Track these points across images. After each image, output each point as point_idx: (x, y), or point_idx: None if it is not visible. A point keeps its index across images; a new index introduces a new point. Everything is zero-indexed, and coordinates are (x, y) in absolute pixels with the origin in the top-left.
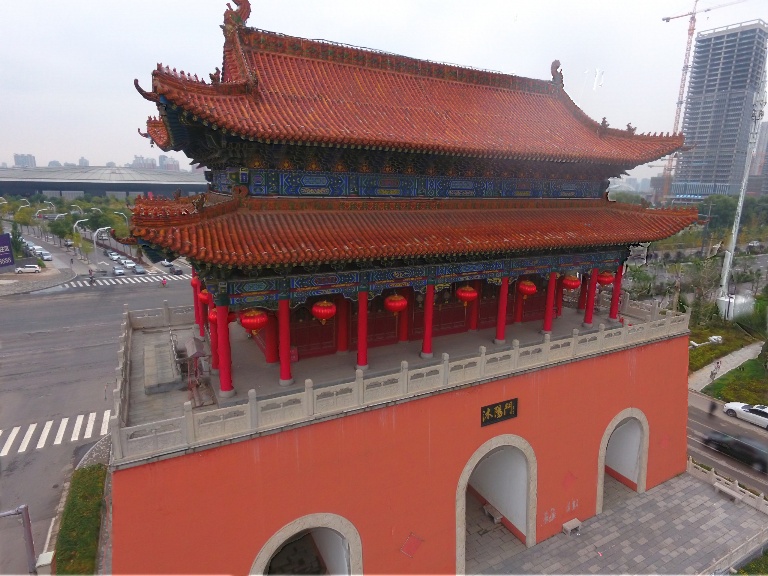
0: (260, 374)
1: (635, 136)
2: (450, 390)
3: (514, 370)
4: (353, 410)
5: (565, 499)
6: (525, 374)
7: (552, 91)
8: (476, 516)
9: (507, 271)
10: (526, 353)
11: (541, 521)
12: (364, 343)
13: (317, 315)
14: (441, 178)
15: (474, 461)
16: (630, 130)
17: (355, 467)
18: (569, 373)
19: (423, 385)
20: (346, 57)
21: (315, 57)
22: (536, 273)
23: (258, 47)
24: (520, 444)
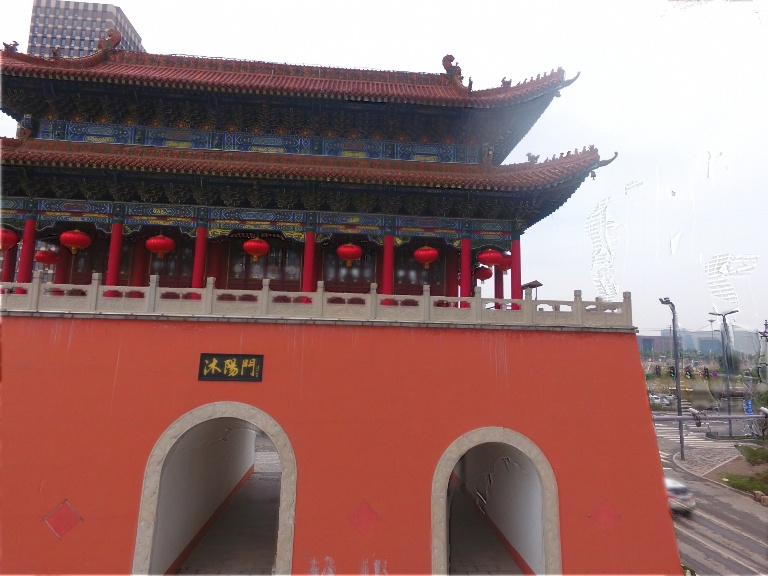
0: None
1: (511, 88)
2: (152, 318)
3: (258, 315)
4: (19, 311)
5: (359, 551)
6: (278, 325)
7: (446, 83)
8: (261, 567)
9: (309, 224)
10: (285, 300)
11: (304, 572)
12: (111, 278)
13: (62, 240)
14: (241, 134)
15: (182, 427)
16: (505, 84)
17: (9, 381)
18: (362, 342)
19: (120, 307)
20: (200, 65)
21: (170, 66)
22: (359, 234)
23: (122, 62)
24: (265, 425)
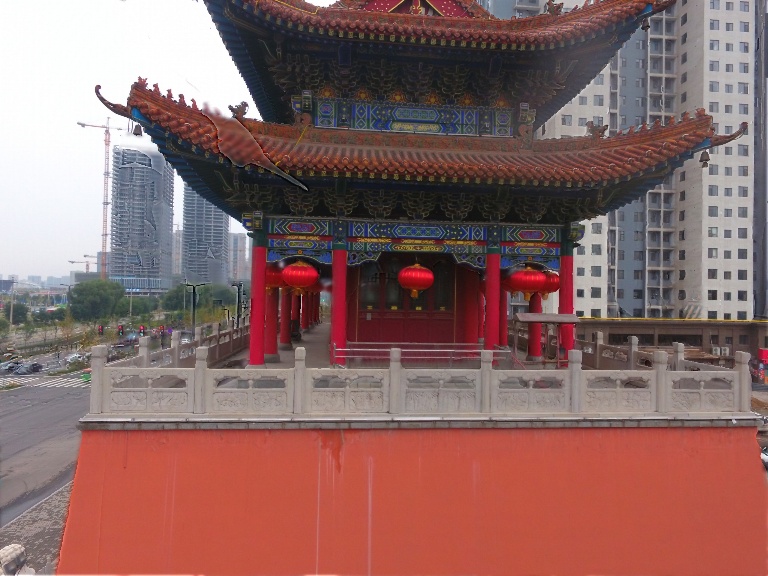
0: (503, 366)
1: None
2: None
3: None
4: None
5: None
6: None
7: None
8: None
9: None
10: None
11: None
12: None
13: None
14: None
15: None
16: None
17: None
18: None
19: None
20: None
21: None
22: None
23: None
24: None
